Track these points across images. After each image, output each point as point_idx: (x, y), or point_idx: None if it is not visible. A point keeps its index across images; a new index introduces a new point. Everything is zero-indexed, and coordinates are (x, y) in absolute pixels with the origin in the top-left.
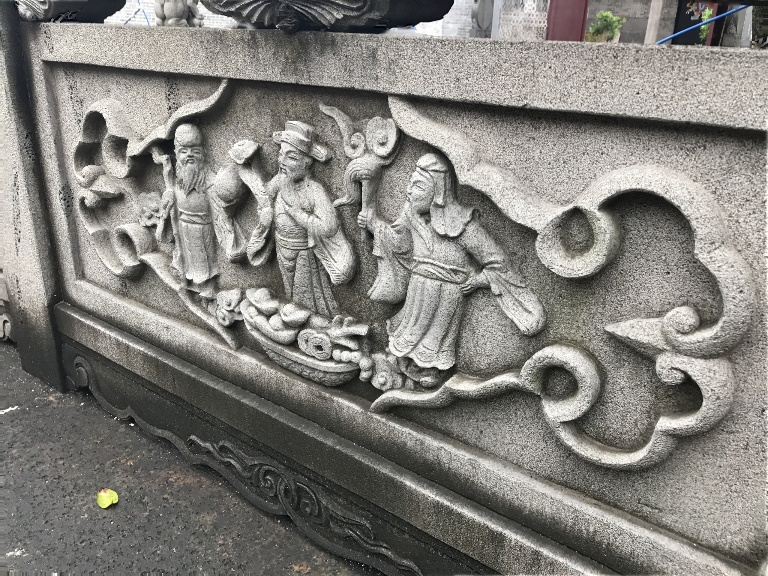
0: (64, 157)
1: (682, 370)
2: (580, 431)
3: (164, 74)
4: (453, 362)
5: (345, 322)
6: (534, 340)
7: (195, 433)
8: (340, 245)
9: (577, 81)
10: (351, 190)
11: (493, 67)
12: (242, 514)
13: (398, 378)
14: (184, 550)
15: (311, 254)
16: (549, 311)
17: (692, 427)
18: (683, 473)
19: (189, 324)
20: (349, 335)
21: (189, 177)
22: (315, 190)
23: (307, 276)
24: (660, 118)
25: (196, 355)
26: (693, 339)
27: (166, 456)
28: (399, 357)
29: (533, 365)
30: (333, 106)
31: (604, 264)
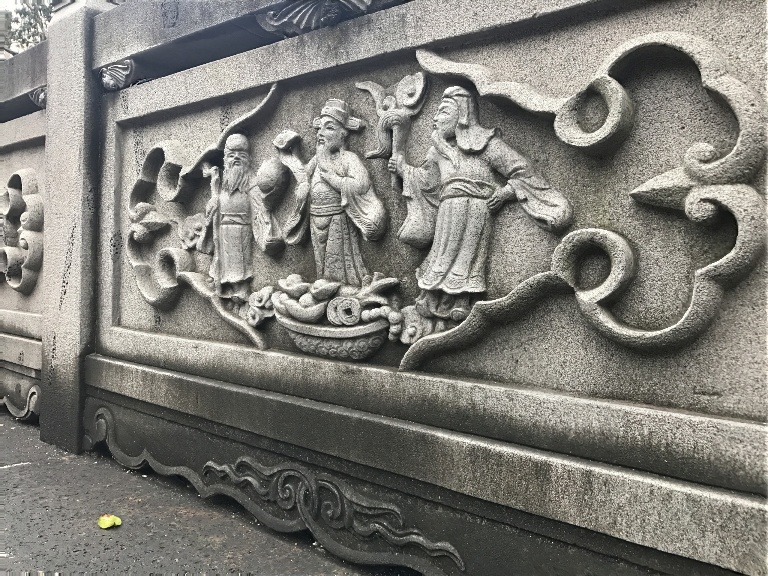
0: (120, 208)
1: (711, 199)
2: (620, 322)
3: (221, 103)
4: (483, 288)
5: (375, 276)
6: None
7: (212, 458)
8: (371, 201)
9: None
10: (382, 139)
11: None
12: (255, 538)
13: (428, 324)
14: (188, 560)
15: (343, 219)
16: (574, 204)
17: (732, 258)
18: (735, 337)
19: (218, 342)
20: (378, 289)
21: (234, 177)
22: (349, 156)
23: (339, 242)
24: None
25: (222, 368)
26: (716, 163)
27: (177, 497)
28: (429, 289)
29: (563, 248)
30: (368, 81)
31: (620, 122)
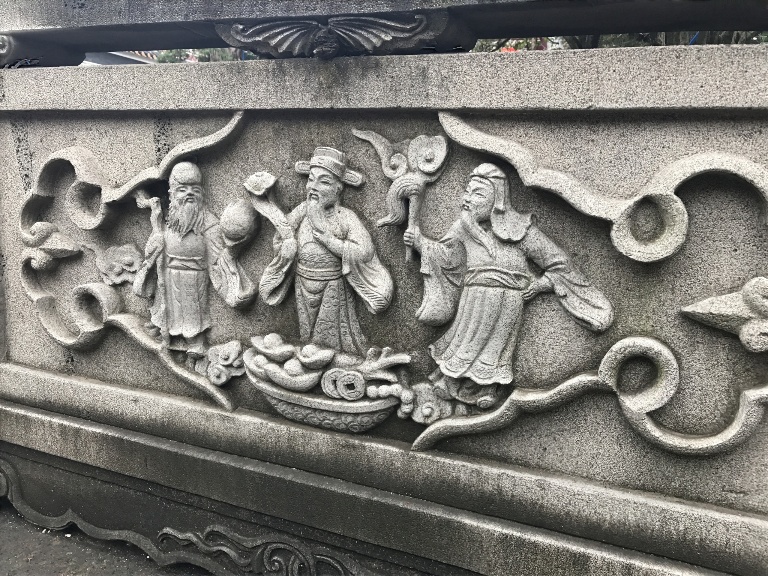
0: None
1: None
2: (657, 425)
3: (154, 115)
4: (512, 377)
5: (384, 352)
6: (602, 338)
7: (170, 524)
8: (378, 270)
9: (642, 81)
10: (397, 208)
11: (556, 75)
12: None
13: (447, 406)
14: None
15: (341, 284)
16: (616, 306)
17: None
18: (767, 447)
19: (163, 393)
20: (388, 366)
21: (188, 217)
22: (348, 215)
23: (335, 309)
24: (724, 106)
25: (175, 427)
26: None
27: (123, 564)
28: (455, 378)
29: (614, 357)
30: (369, 130)
31: (683, 244)
